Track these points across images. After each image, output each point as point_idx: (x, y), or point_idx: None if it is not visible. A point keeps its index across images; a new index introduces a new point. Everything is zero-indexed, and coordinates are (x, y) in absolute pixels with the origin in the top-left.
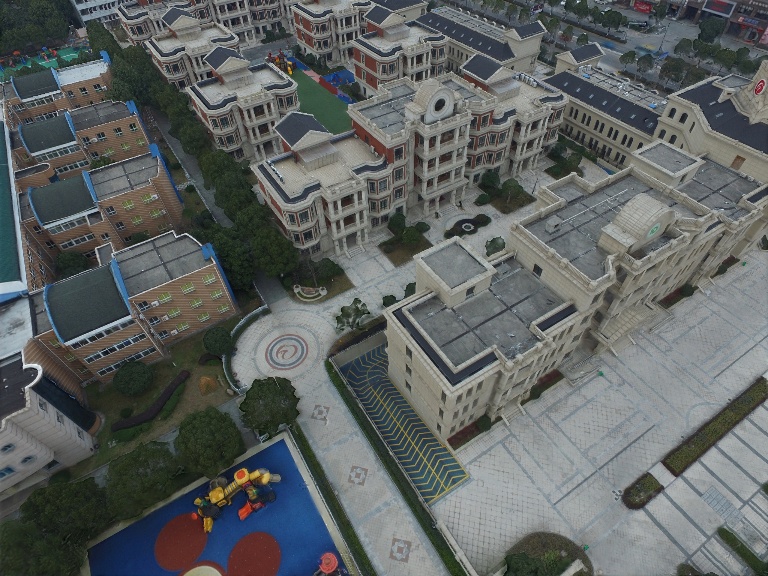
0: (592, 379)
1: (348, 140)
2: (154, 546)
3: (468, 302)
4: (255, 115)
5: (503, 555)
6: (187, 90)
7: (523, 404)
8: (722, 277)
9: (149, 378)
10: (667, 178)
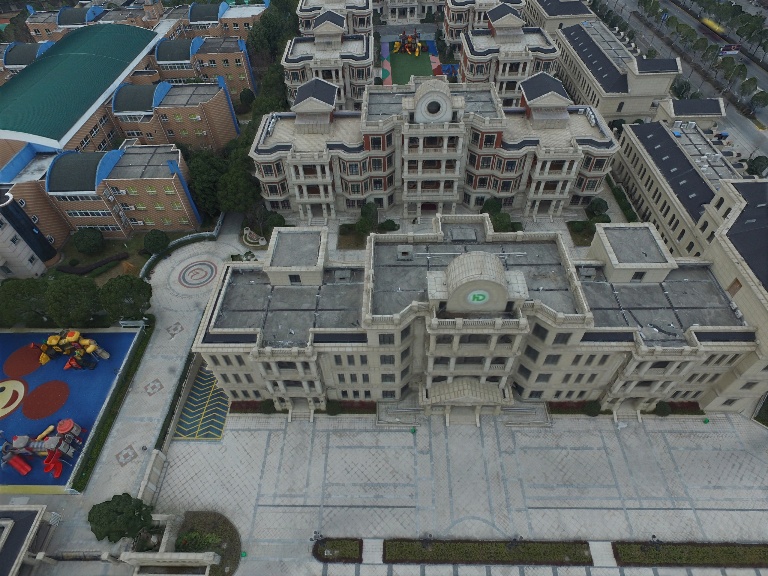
0: (401, 431)
1: (357, 119)
2: (12, 353)
3: (291, 288)
4: (324, 78)
5: (183, 511)
6: (288, 42)
7: (317, 412)
8: (660, 420)
9: (97, 245)
10: (611, 266)
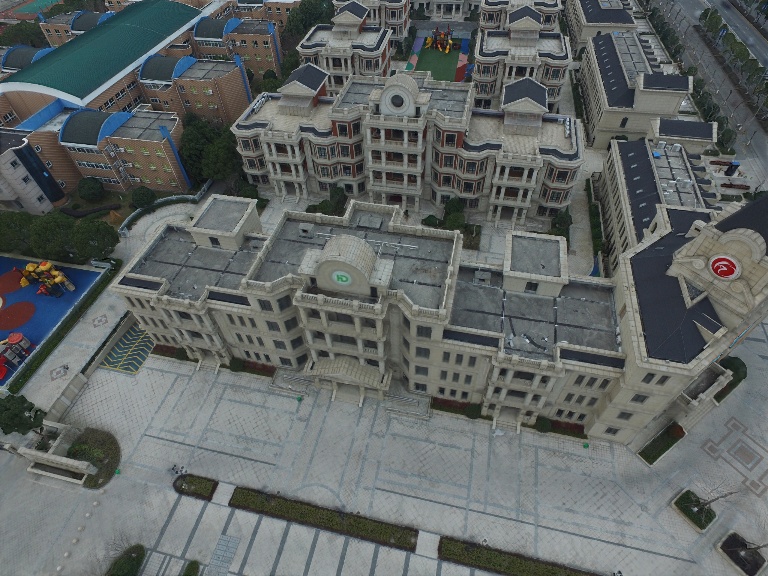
0: (289, 397)
1: None
2: (3, 274)
3: (211, 249)
4: (334, 65)
5: (84, 427)
6: (311, 29)
7: (222, 367)
8: (539, 435)
9: (95, 193)
10: None
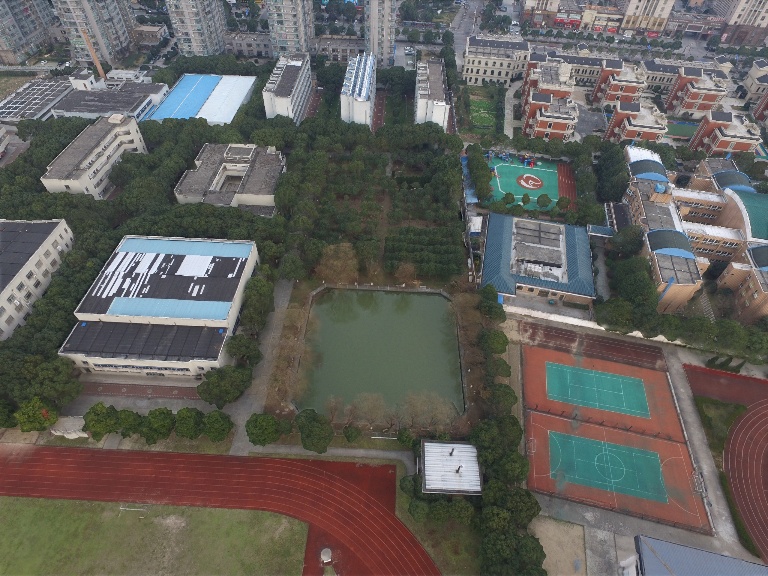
0: None
1: None
2: None
3: None
4: None
5: None
6: (725, 138)
7: None
8: None
9: None
10: None
